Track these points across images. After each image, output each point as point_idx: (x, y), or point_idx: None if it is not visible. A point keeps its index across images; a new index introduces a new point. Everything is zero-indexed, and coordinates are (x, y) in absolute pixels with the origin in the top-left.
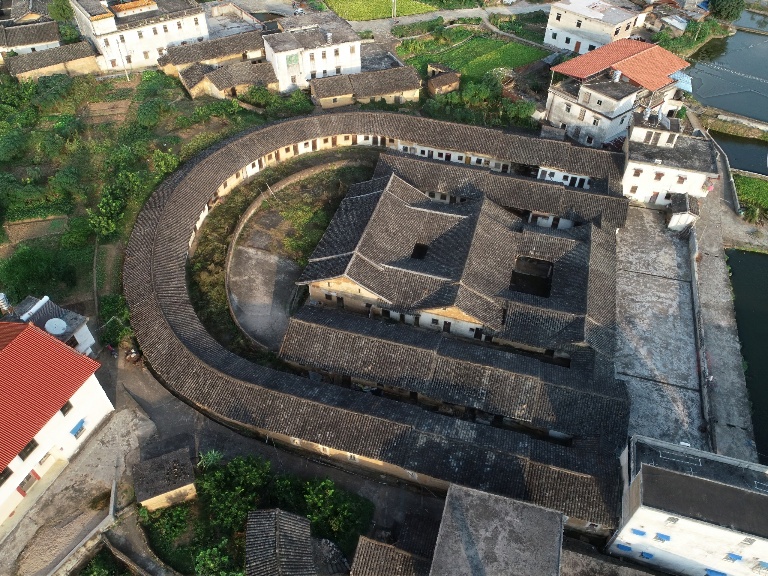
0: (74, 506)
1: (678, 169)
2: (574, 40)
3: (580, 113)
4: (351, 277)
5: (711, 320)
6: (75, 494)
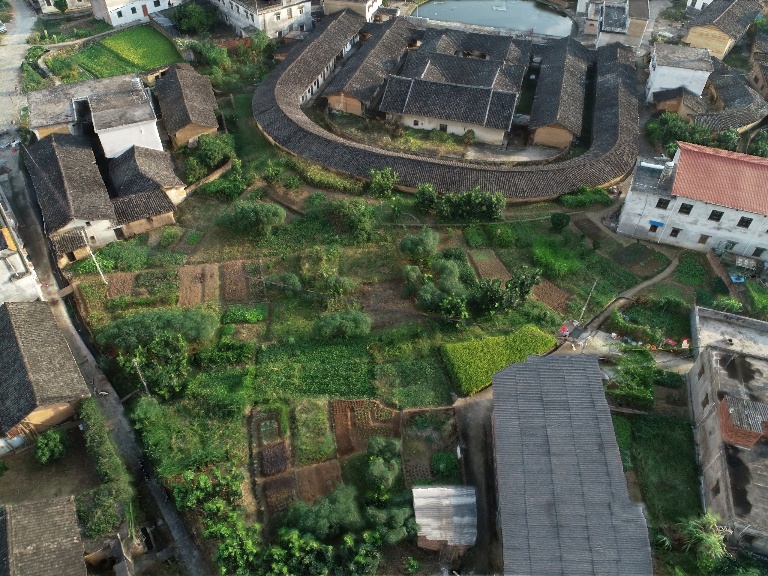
0: None
1: None
2: (139, 6)
3: (287, 14)
4: None
5: None
6: None
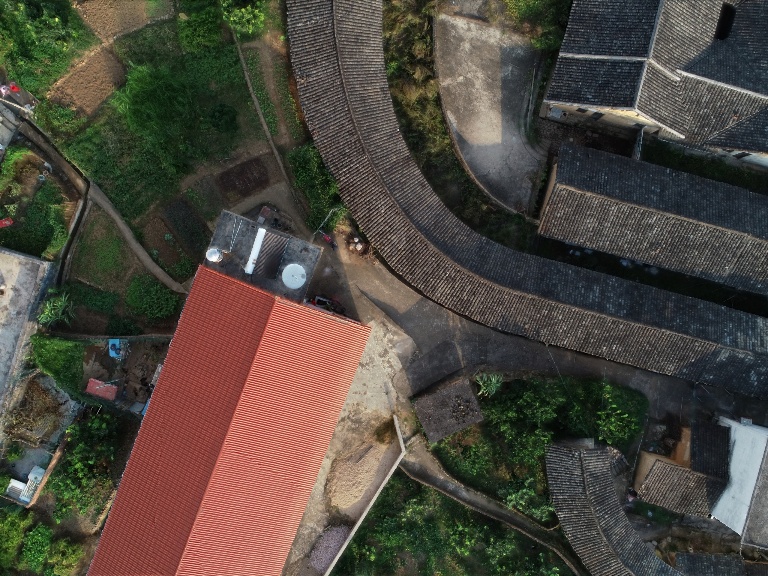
0: (359, 439)
1: None
2: None
3: None
4: (641, 110)
5: None
6: (354, 426)
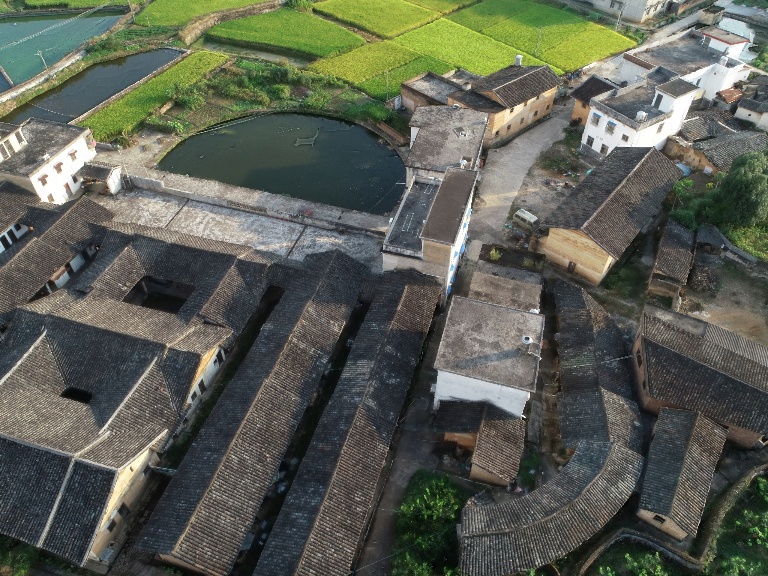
0: None
1: (65, 149)
2: None
3: None
4: (122, 465)
5: (237, 199)
6: None
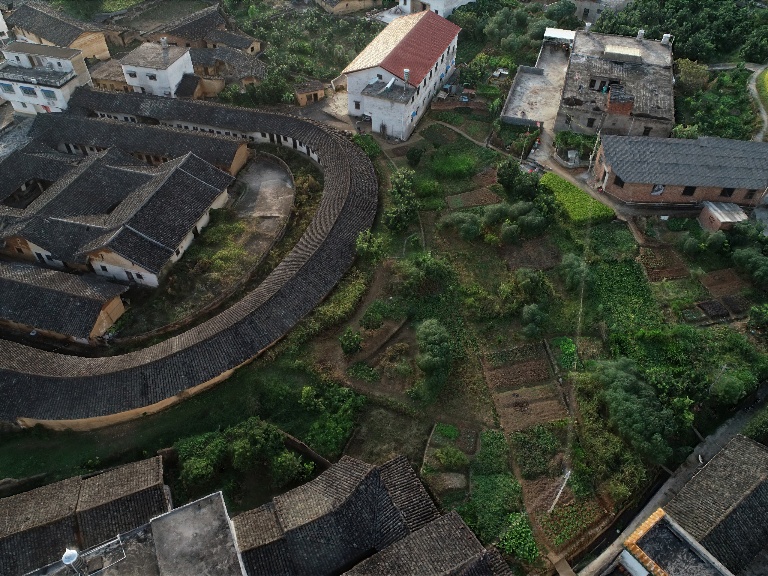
0: None
1: None
2: None
3: None
4: None
5: None
6: None
